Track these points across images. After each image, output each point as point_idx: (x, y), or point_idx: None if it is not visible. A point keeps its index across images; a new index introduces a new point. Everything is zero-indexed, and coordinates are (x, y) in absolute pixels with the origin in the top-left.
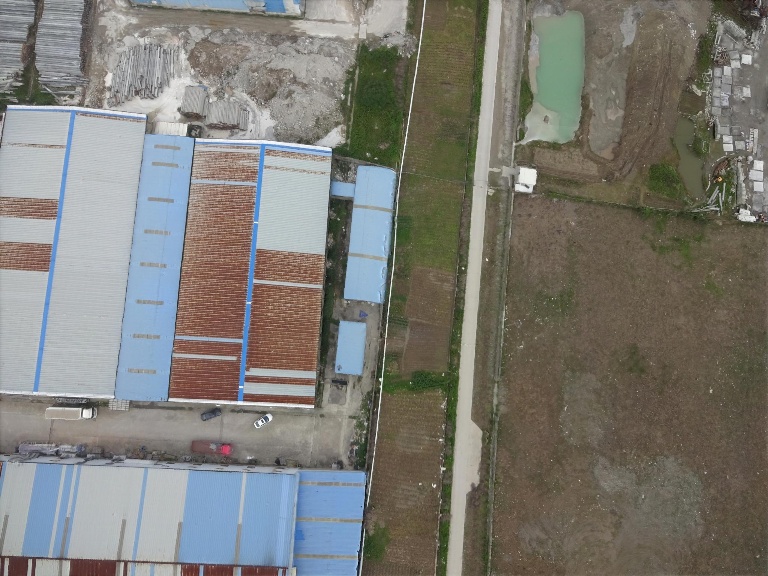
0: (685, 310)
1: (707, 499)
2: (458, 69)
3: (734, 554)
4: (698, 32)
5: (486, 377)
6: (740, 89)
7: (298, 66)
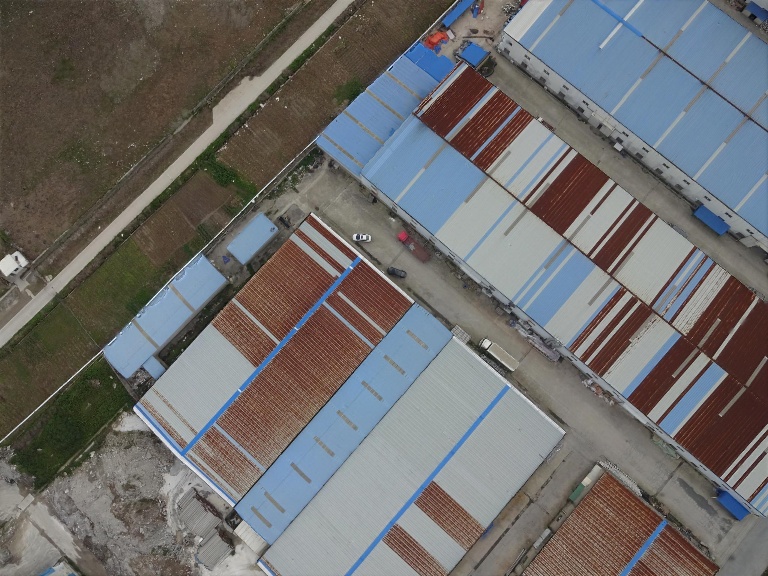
0: None
1: None
2: None
3: None
4: None
5: (177, 144)
6: None
7: (101, 509)
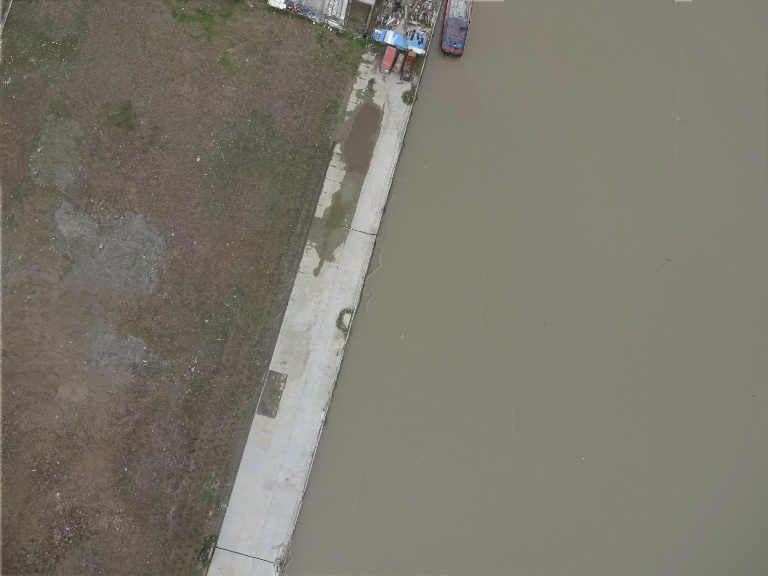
0: (191, 79)
1: (168, 259)
2: None
3: (183, 315)
4: None
5: None
6: None
7: None
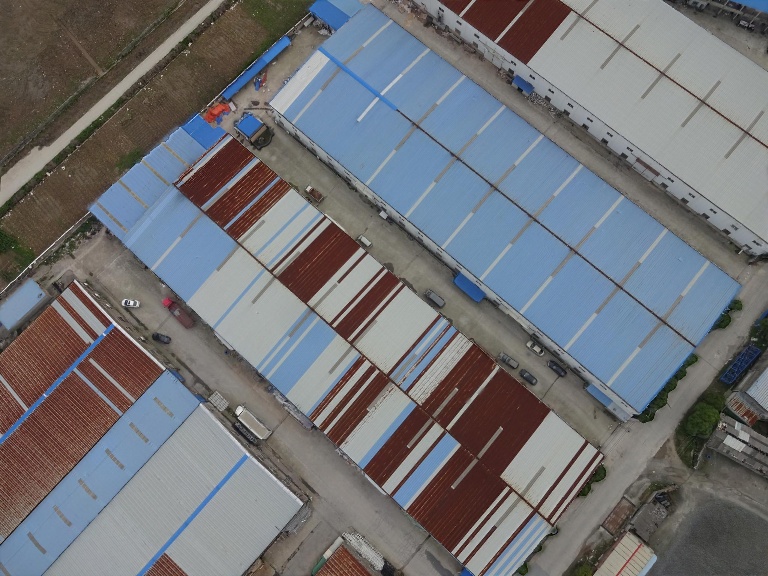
0: None
1: None
2: None
3: None
4: None
5: None
6: None
7: None
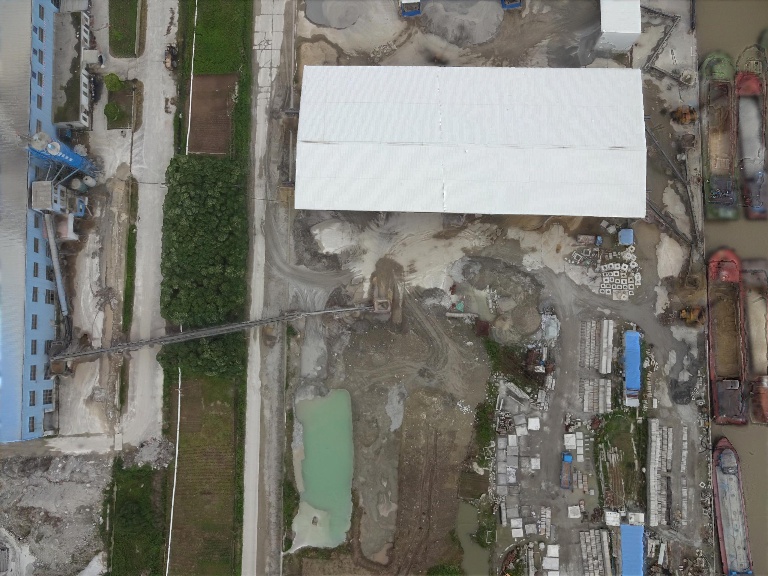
0: None
1: None
2: (218, 475)
3: None
4: (473, 404)
5: None
6: (528, 460)
7: (46, 504)
